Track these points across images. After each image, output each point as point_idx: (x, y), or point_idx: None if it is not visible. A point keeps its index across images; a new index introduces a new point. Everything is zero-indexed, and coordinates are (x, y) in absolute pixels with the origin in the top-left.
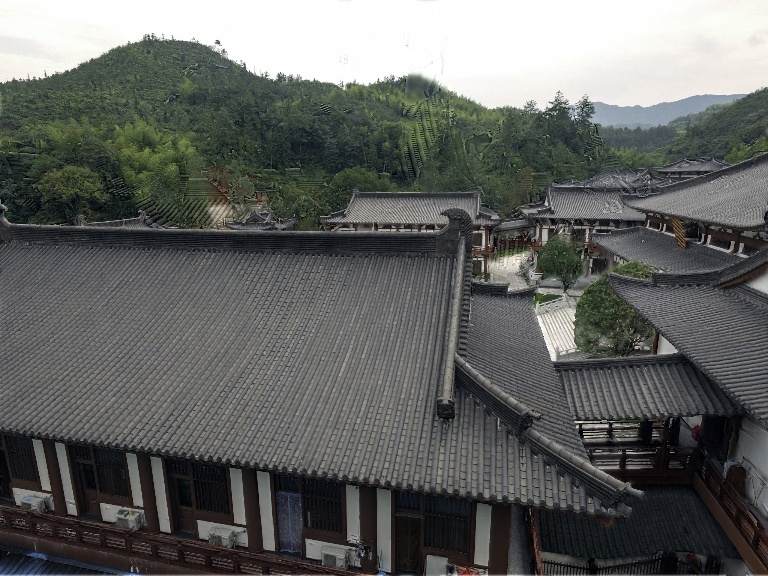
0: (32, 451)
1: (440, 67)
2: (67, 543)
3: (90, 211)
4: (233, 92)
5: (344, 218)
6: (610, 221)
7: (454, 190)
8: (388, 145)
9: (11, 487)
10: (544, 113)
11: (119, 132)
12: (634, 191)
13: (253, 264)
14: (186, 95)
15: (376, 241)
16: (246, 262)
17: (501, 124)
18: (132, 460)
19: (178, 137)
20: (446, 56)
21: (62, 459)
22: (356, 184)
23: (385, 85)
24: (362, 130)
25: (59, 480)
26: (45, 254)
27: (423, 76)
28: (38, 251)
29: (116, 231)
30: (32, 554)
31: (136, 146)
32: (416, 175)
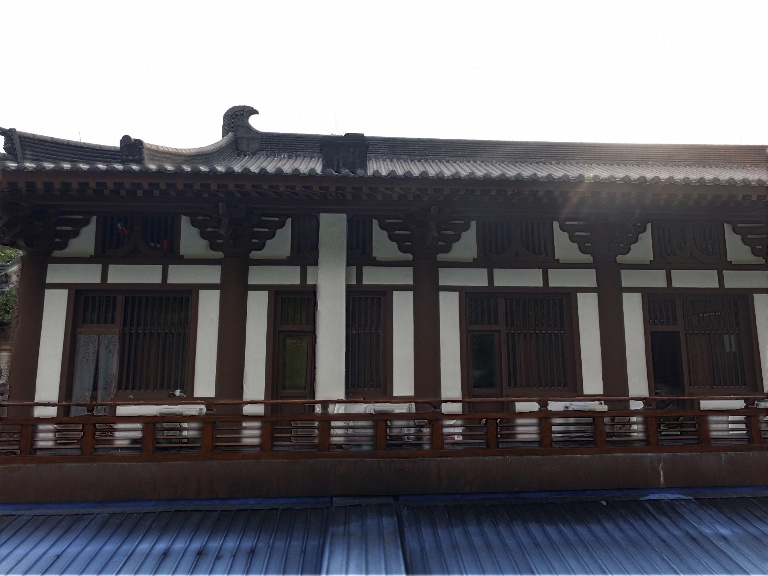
0: (574, 316)
1: None
2: (734, 449)
3: None
4: None
5: None
6: None
7: None
8: None
9: None
10: None
11: None
12: None
13: (632, 169)
14: None
15: (750, 153)
16: None
17: None
18: (765, 305)
19: None
20: None
21: (634, 323)
22: None
23: None
24: None
25: (623, 366)
26: None
27: None
28: (311, 161)
29: (430, 140)
30: (652, 496)
31: None
32: None
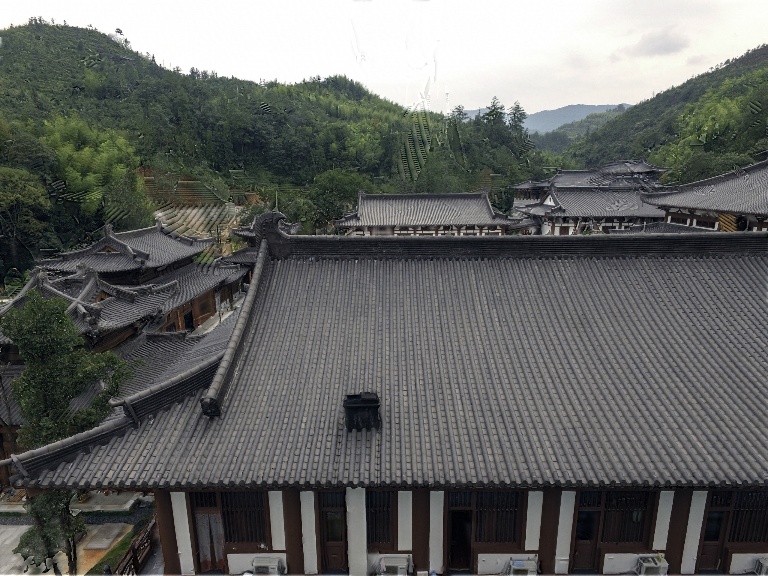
0: (524, 506)
1: (434, 69)
2: None
3: (34, 220)
4: (163, 86)
5: (359, 221)
6: (614, 218)
7: (463, 191)
8: (335, 146)
9: (477, 554)
10: (482, 117)
11: (52, 128)
12: (653, 190)
13: (627, 270)
14: (93, 88)
15: (752, 241)
16: (615, 268)
17: (443, 127)
18: (667, 498)
19: (115, 135)
20: (438, 58)
21: (567, 510)
22: (343, 186)
23: (312, 85)
24: (306, 130)
25: (555, 535)
26: (349, 270)
27: (419, 77)
28: (335, 267)
29: (442, 240)
30: None
31: (73, 144)
32: (412, 176)
